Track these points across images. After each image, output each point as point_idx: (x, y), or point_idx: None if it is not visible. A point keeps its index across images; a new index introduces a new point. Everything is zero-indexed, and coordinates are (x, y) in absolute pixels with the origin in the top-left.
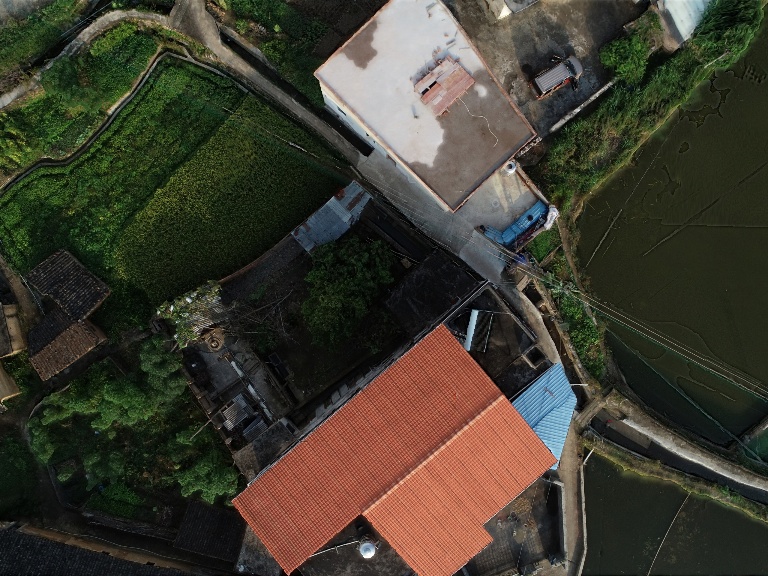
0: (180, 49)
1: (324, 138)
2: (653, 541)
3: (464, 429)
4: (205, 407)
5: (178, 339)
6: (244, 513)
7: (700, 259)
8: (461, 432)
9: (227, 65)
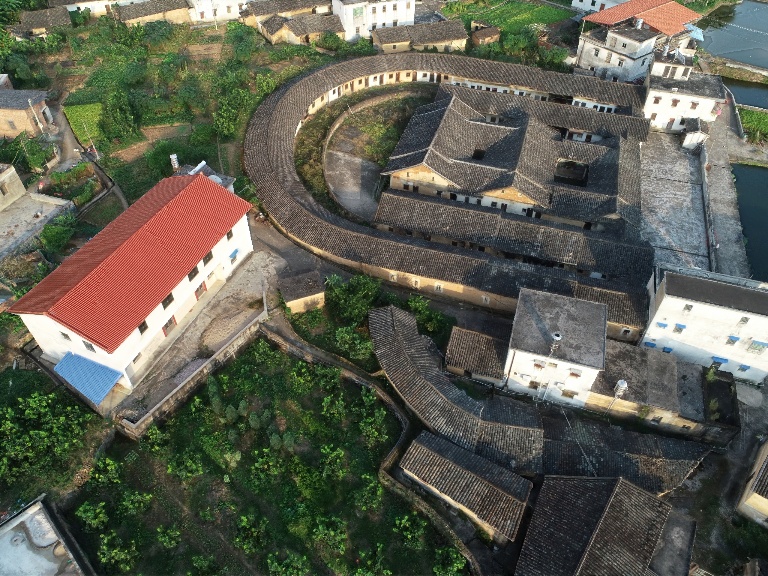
0: (515, 0)
1: (573, 12)
2: (763, 95)
3: (664, 5)
4: None
5: (534, 29)
6: None
7: (734, 55)
8: (663, 5)
9: (534, 0)
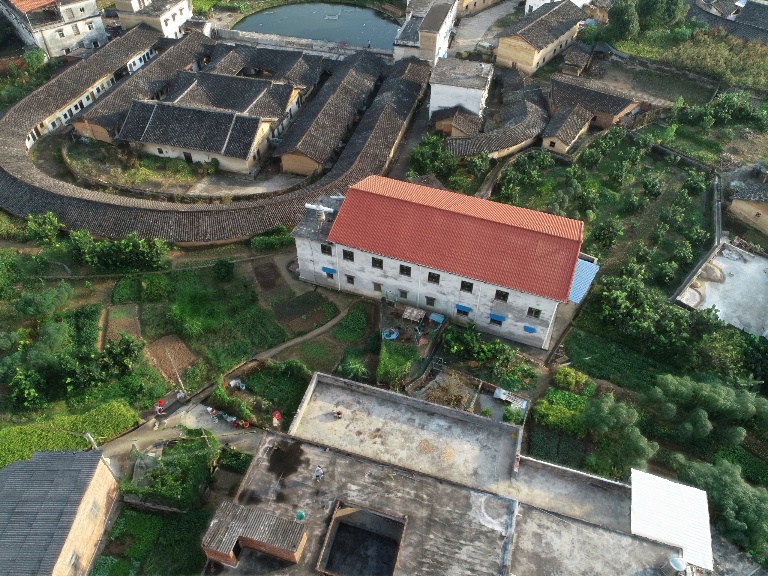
0: None
1: None
2: None
3: None
4: (1, 63)
5: None
6: (29, 9)
7: None
8: None
9: None
